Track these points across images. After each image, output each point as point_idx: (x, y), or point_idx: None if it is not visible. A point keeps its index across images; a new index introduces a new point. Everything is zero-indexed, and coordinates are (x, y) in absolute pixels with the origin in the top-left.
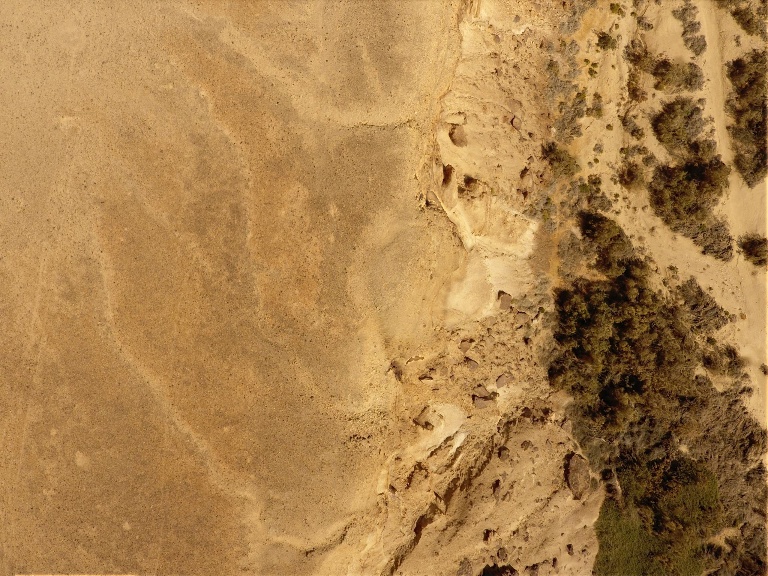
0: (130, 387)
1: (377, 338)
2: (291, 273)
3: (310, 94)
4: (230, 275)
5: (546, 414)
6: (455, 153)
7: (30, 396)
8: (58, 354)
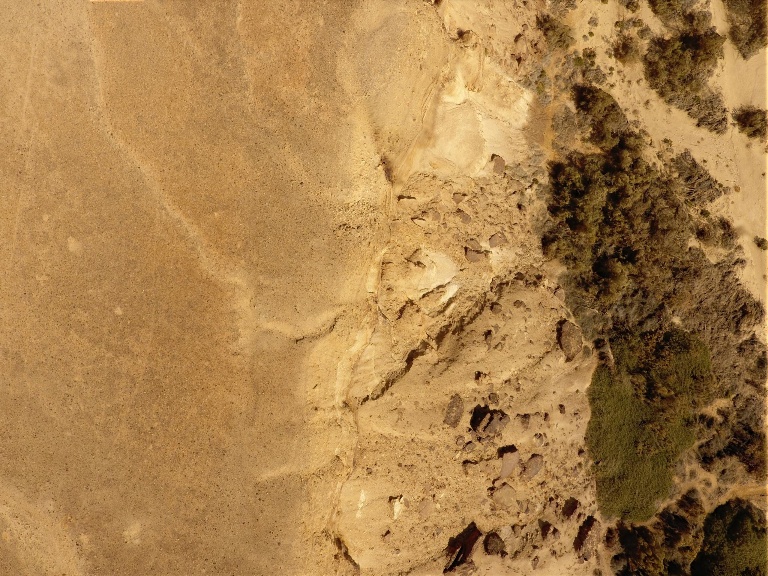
0: (121, 172)
1: (367, 129)
2: (281, 56)
3: None
4: (220, 59)
5: (539, 279)
6: (448, 2)
7: (23, 181)
8: (50, 139)
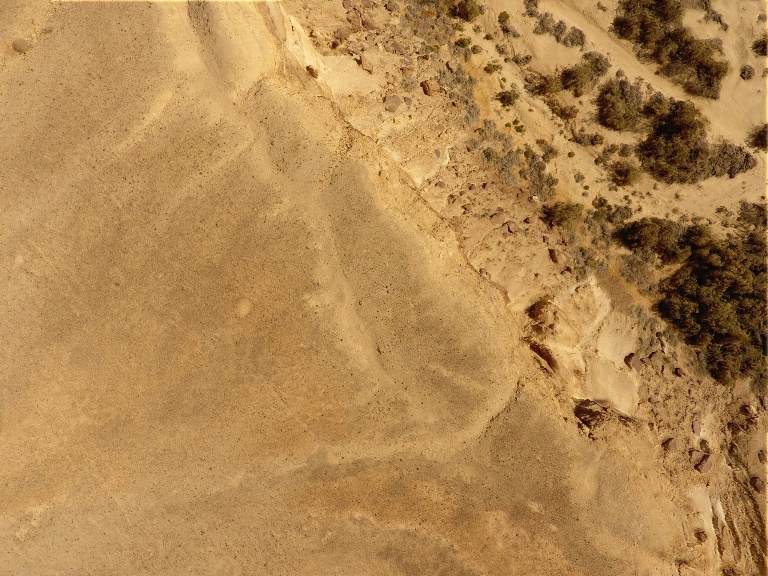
0: None
1: (652, 561)
2: None
3: (434, 439)
4: None
5: (748, 415)
6: None
7: None
8: None
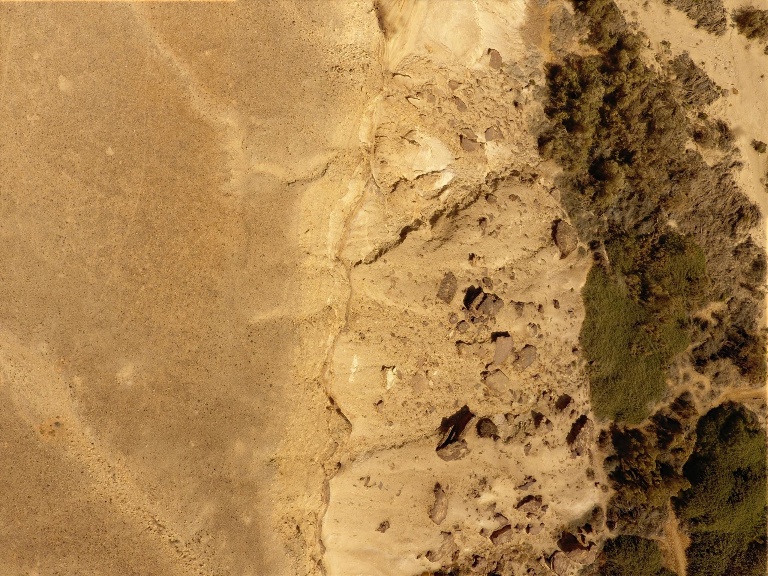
0: (112, 9)
1: None
2: None
3: None
4: None
5: (535, 176)
6: None
7: (13, 19)
8: None
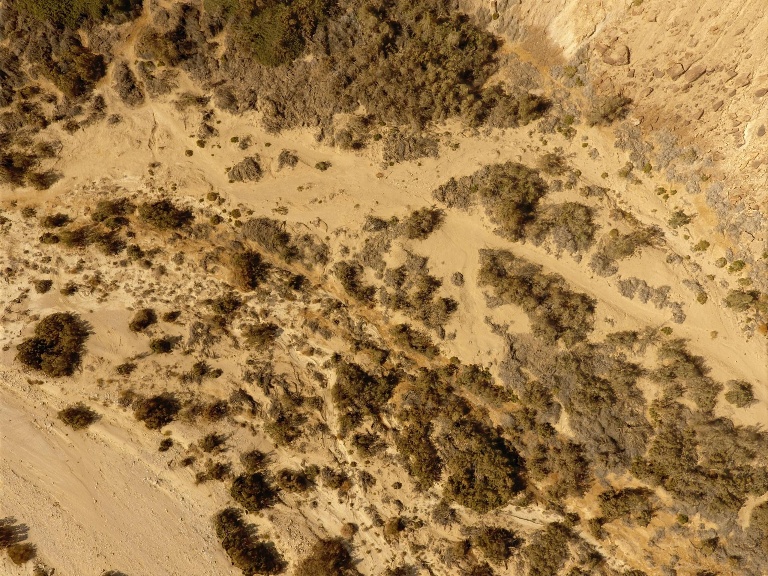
0: None
1: None
2: None
3: None
4: None
5: None
6: None
7: None
8: None
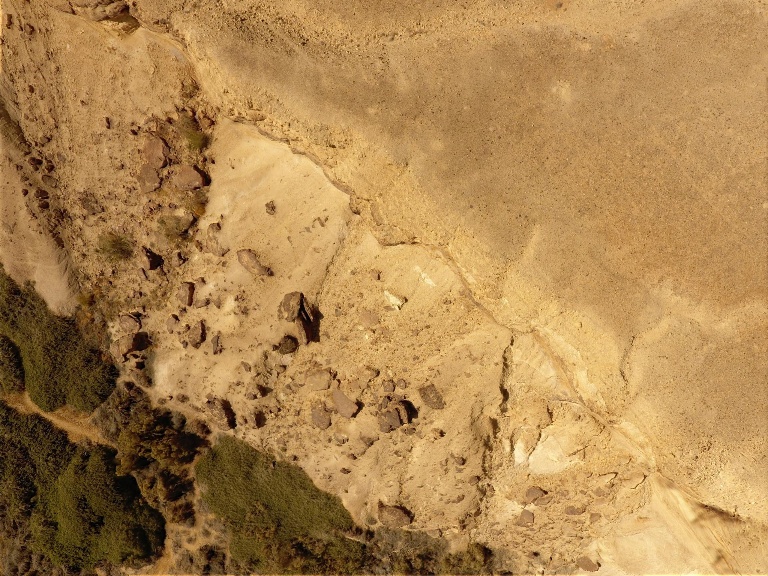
0: None
1: None
2: None
3: None
4: None
5: None
6: None
7: None
8: None
